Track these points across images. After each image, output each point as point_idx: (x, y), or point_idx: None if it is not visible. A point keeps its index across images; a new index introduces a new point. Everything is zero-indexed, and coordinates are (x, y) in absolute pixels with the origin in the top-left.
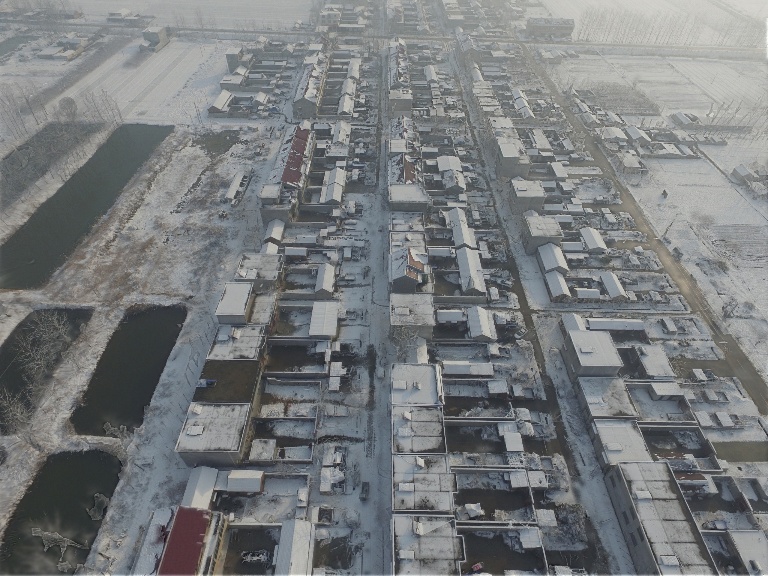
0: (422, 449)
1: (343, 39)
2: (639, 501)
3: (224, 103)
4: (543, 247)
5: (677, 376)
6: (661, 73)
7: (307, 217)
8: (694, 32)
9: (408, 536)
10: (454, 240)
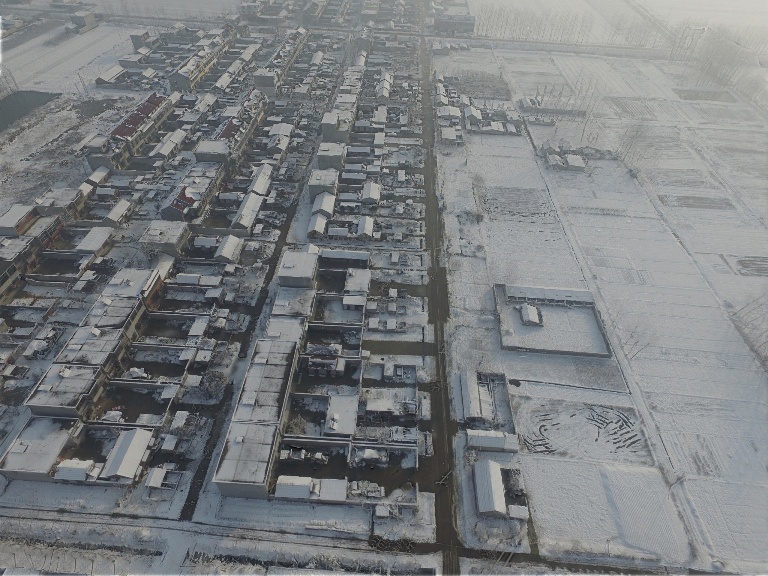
0: (105, 324)
1: (258, 28)
2: (254, 365)
3: (113, 76)
4: (319, 195)
5: (377, 294)
6: (538, 66)
7: (136, 167)
8: (584, 30)
9: (54, 377)
10: (249, 188)
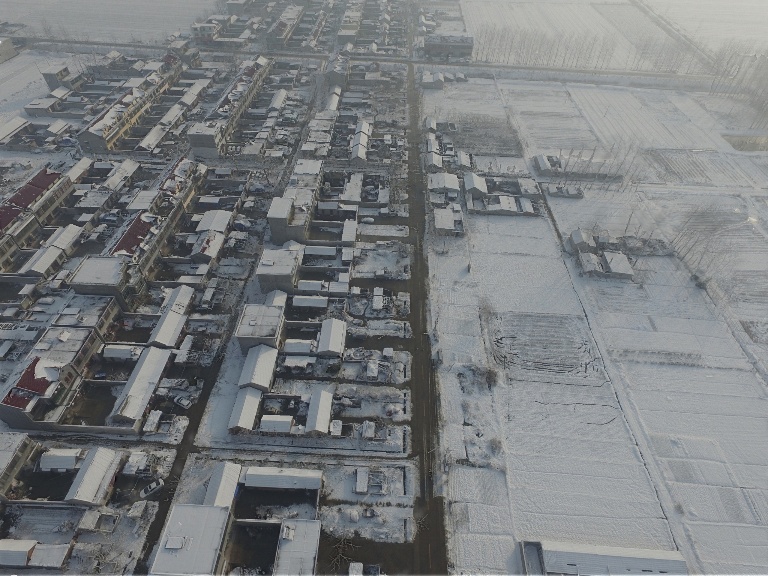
0: None
1: (212, 55)
2: None
3: (8, 133)
4: (253, 349)
5: (330, 572)
6: (552, 102)
7: None
8: (604, 55)
9: None
10: (151, 333)
